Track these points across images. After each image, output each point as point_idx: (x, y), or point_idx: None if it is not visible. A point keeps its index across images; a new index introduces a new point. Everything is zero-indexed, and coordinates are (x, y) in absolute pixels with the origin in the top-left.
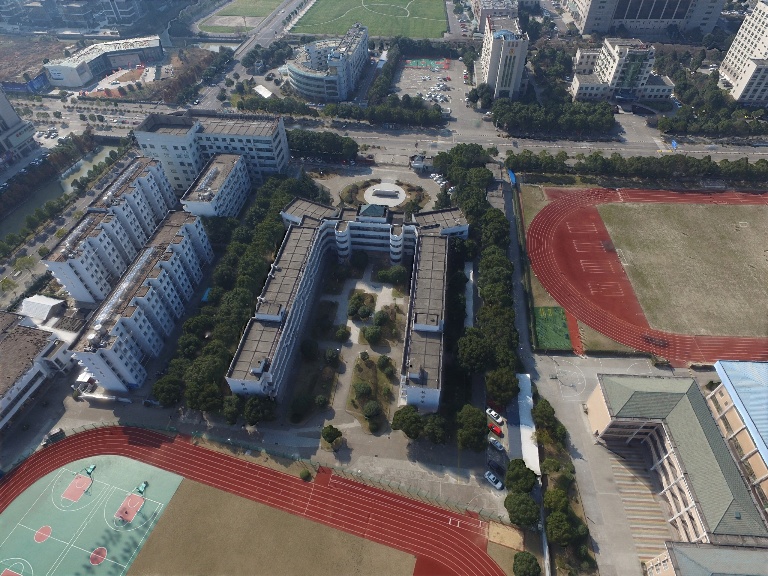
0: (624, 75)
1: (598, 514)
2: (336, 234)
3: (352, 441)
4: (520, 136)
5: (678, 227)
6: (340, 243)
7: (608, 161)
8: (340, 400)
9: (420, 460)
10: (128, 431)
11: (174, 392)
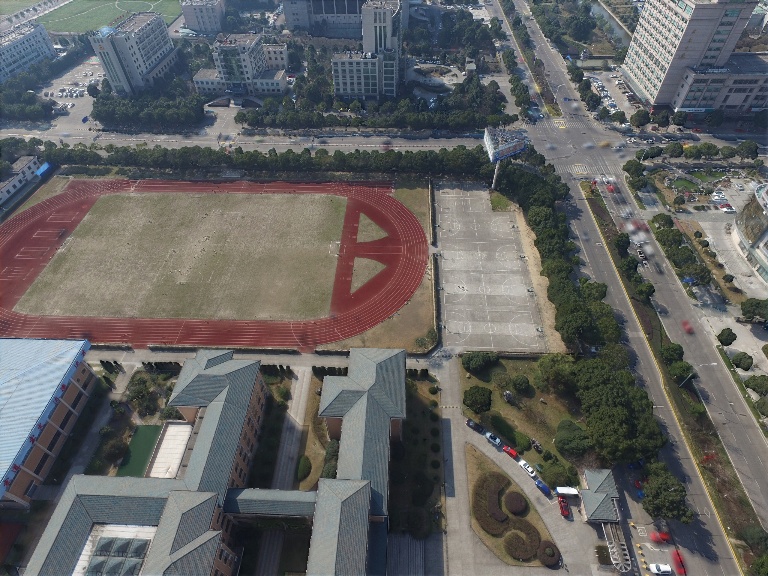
0: (227, 69)
1: None
2: None
3: None
4: (109, 130)
5: (152, 215)
6: None
7: (131, 153)
8: None
9: None
10: None
11: None
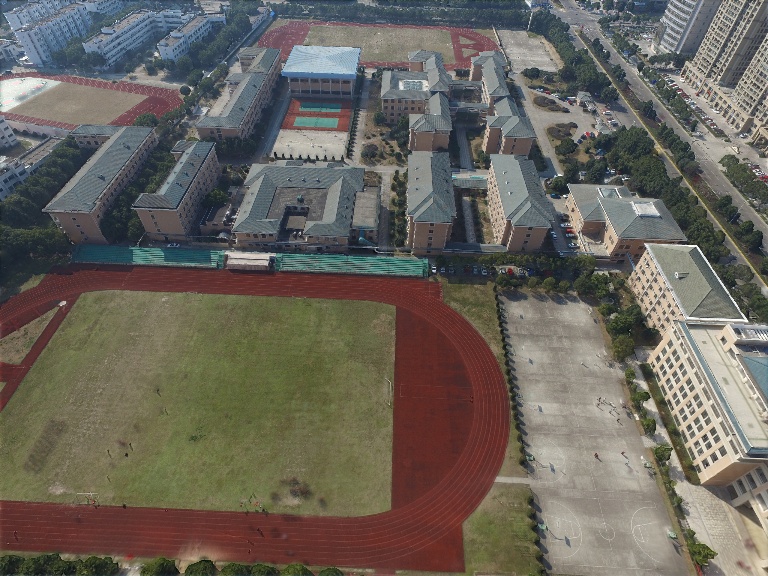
0: None
1: None
2: (155, 17)
3: (139, 77)
4: (295, 3)
5: (346, 33)
6: (158, 22)
7: (324, 6)
8: (139, 69)
9: None
10: (41, 73)
11: (61, 55)
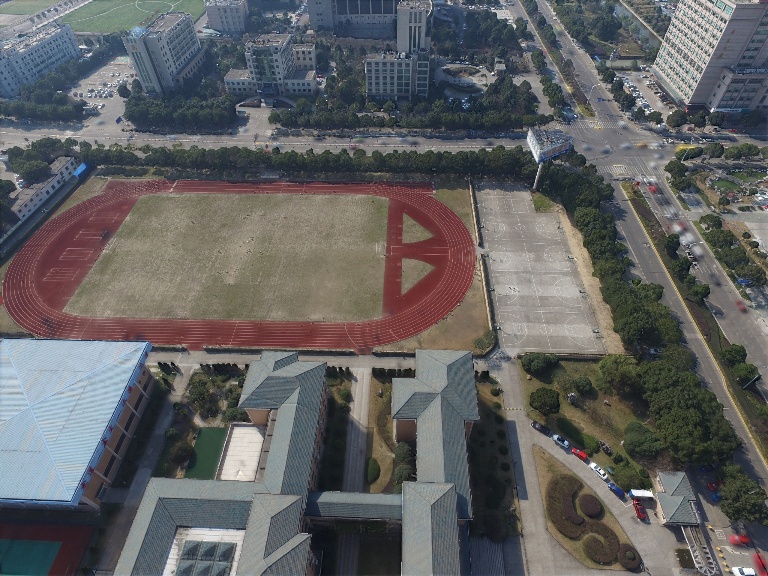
0: (259, 70)
1: None
2: None
3: None
4: (142, 130)
5: (194, 216)
6: None
7: (169, 153)
8: None
9: None
10: None
11: None
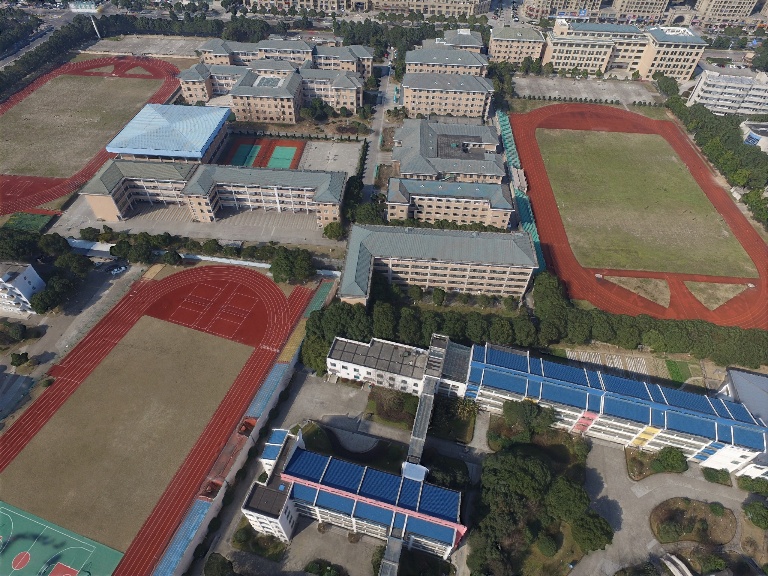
0: None
1: (163, 231)
2: None
3: (38, 352)
4: None
5: None
6: None
7: None
8: None
9: (81, 308)
10: None
11: None
